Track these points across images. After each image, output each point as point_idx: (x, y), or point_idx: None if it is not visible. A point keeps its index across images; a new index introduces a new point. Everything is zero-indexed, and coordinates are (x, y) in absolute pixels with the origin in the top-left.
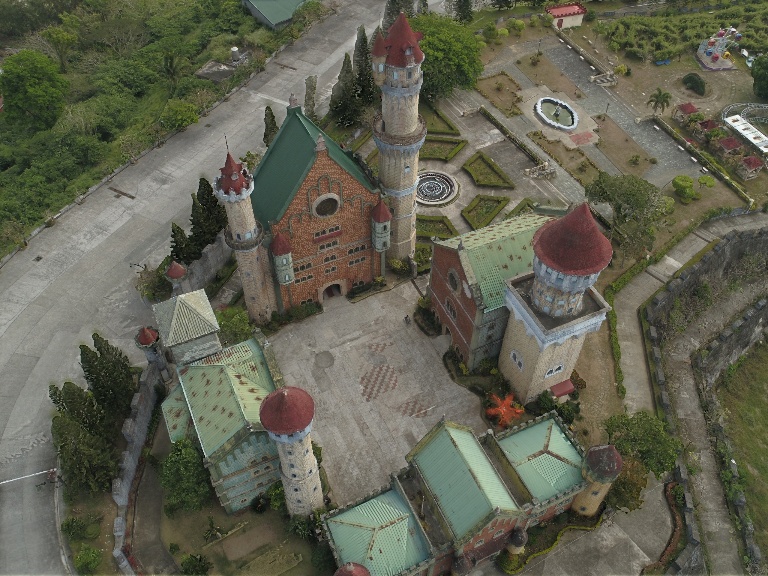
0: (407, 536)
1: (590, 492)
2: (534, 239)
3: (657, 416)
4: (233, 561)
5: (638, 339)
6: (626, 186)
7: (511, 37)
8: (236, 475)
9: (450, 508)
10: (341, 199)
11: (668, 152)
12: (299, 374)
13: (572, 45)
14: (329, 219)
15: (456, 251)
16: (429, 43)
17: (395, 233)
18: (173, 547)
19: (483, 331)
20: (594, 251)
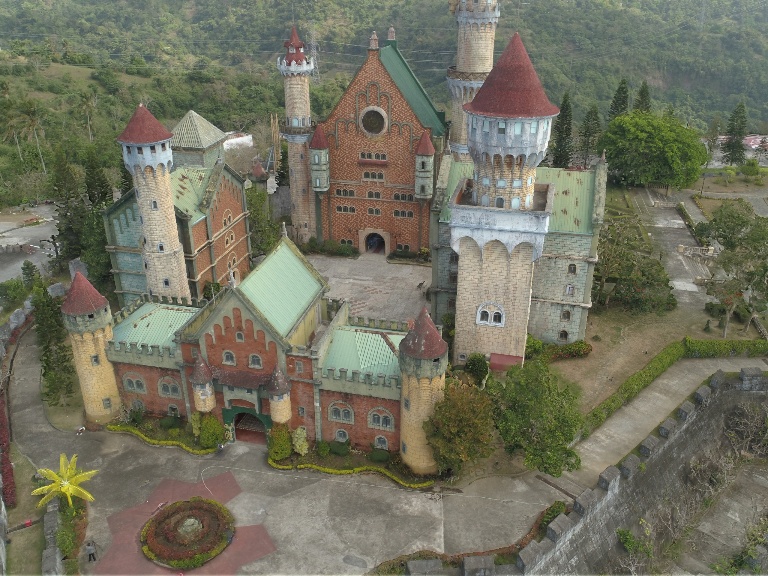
0: (181, 327)
1: (403, 402)
2: None
3: (623, 457)
4: None
5: (681, 399)
6: (735, 207)
7: None
8: (129, 253)
9: None
10: (389, 119)
11: None
12: None
13: None
14: (376, 141)
15: None
16: (637, 124)
17: None
18: (59, 301)
19: (443, 259)
20: (515, 95)
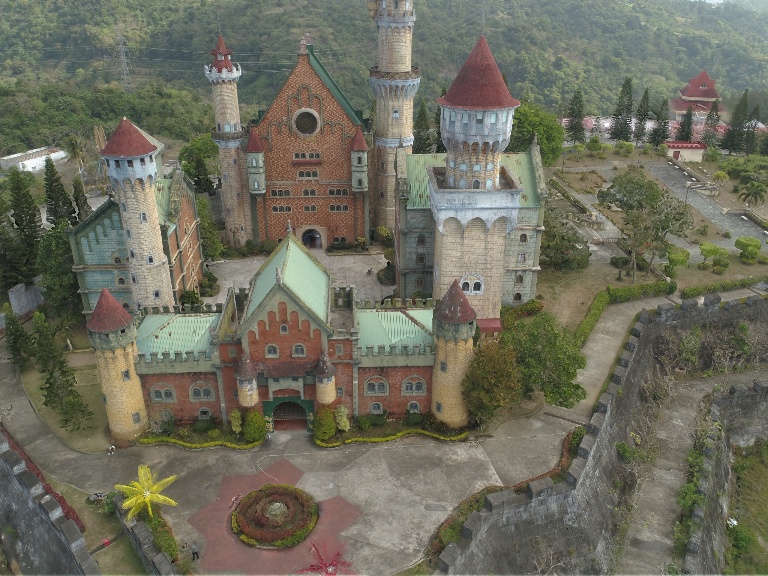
0: (205, 331)
1: (439, 366)
2: None
3: None
4: None
5: (621, 336)
6: (632, 174)
7: (618, 157)
8: (99, 271)
9: (254, 303)
10: (321, 119)
11: (749, 234)
12: (240, 282)
13: (680, 166)
14: (309, 141)
15: None
16: None
17: (385, 195)
18: None
19: (411, 243)
20: (488, 90)
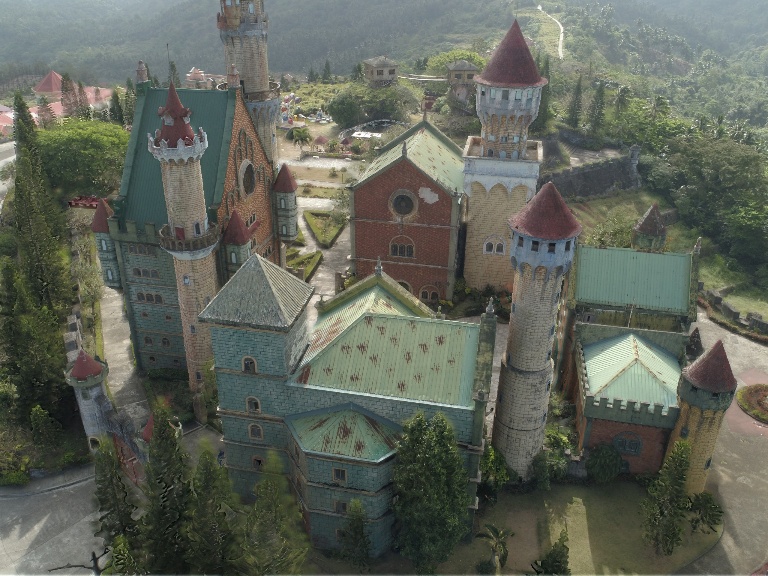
0: (652, 352)
1: None
2: (485, 83)
3: None
4: (539, 567)
5: None
6: None
7: None
8: None
9: (653, 298)
10: None
11: (344, 164)
12: None
13: None
14: (248, 203)
15: (400, 161)
16: None
17: None
18: None
19: None
20: None
